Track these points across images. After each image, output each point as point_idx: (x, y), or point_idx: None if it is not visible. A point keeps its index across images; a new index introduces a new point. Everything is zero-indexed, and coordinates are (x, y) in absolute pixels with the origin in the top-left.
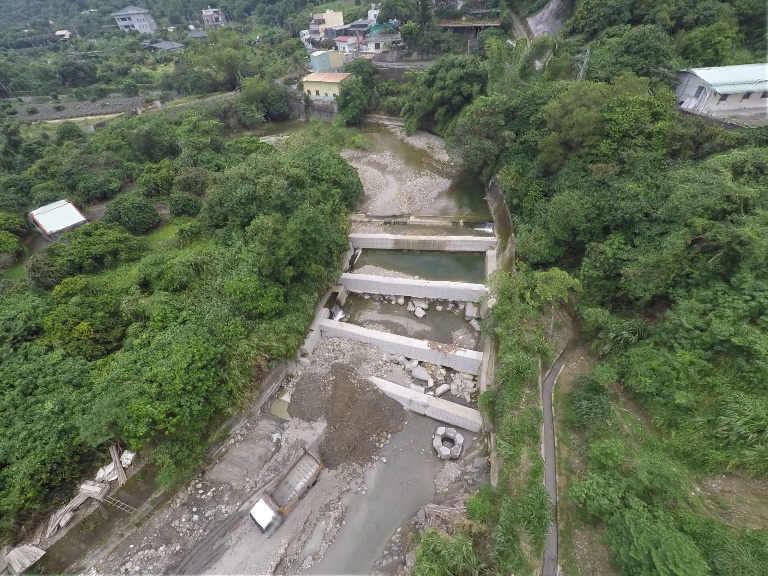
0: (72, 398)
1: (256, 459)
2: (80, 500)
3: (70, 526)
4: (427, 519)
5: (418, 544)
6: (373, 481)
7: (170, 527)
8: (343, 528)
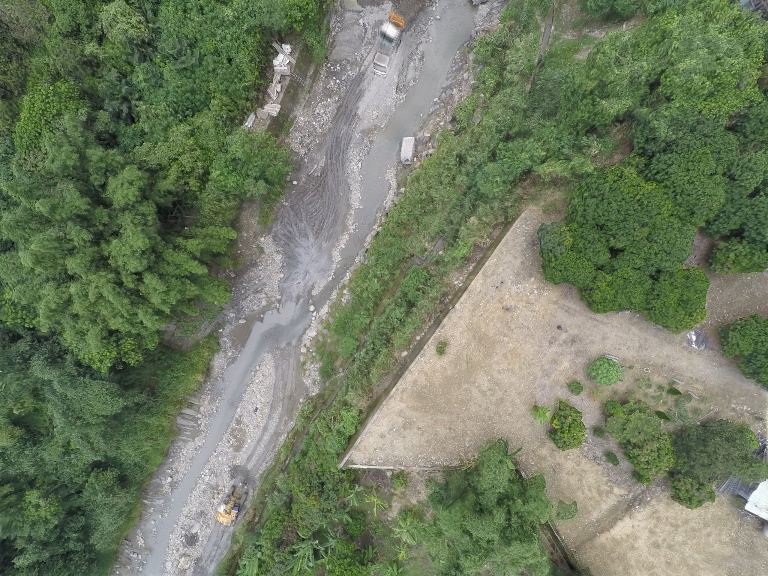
0: (236, 6)
1: (357, 38)
2: (278, 77)
3: (283, 91)
4: (478, 34)
5: (474, 49)
6: (434, 33)
7: (327, 89)
8: (425, 63)
